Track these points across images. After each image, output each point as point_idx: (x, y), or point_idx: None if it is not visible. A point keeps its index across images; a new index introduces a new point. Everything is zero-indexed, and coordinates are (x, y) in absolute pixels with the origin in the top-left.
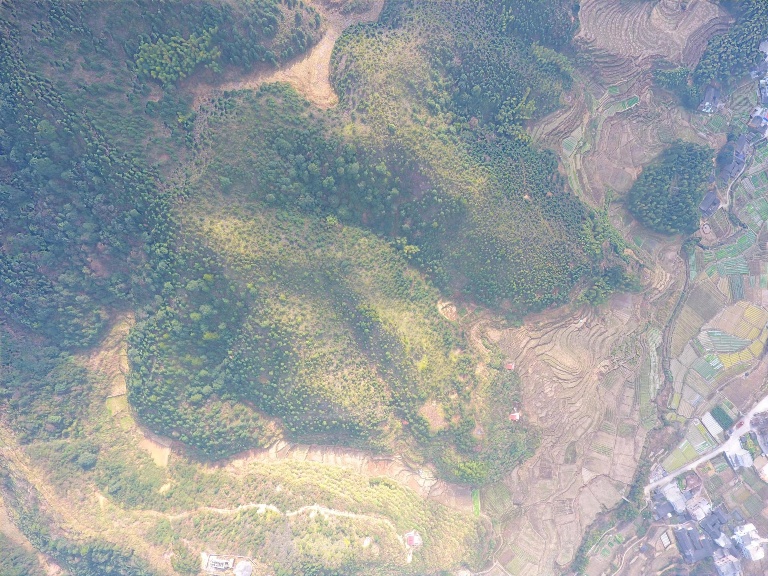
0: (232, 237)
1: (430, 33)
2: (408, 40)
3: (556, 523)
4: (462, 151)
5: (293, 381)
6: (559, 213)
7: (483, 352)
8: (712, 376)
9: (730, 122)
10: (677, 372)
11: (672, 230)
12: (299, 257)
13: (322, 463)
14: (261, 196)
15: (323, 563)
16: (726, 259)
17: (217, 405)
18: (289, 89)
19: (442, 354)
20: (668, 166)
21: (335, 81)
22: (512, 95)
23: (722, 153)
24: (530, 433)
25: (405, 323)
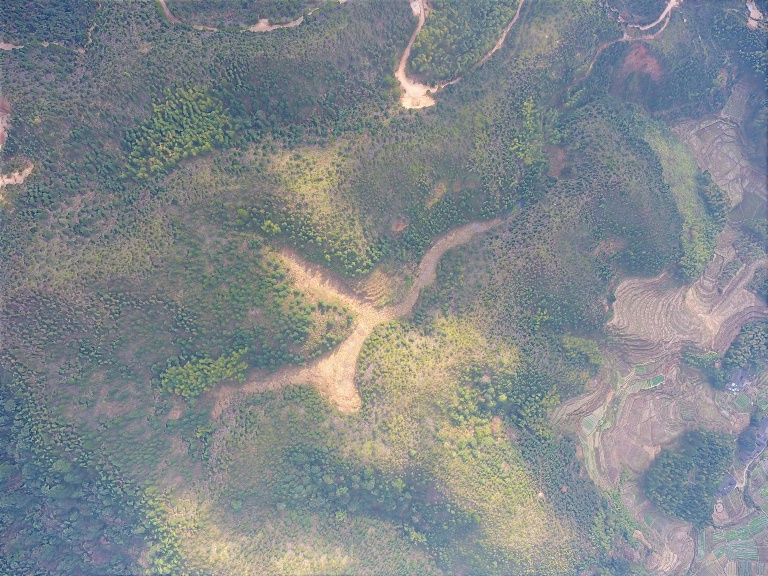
0: (237, 562)
1: (462, 354)
2: (439, 359)
3: None
4: (481, 465)
5: None
6: (572, 510)
7: None
8: None
9: (755, 402)
10: None
11: (685, 522)
12: (303, 569)
13: None
14: (272, 503)
15: None
16: (736, 542)
17: None
18: (313, 396)
19: None
20: (688, 462)
21: (360, 386)
22: (537, 390)
23: (743, 440)
24: None
25: None
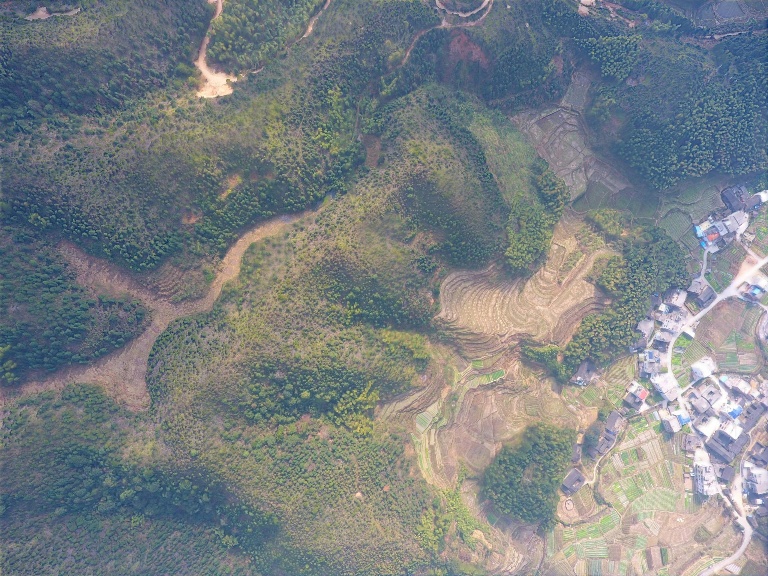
0: (0, 570)
1: (250, 349)
2: (225, 355)
3: None
4: (279, 464)
5: None
6: (394, 510)
7: None
8: None
9: (603, 396)
10: None
11: (522, 521)
12: None
13: None
14: (51, 508)
15: None
16: (586, 540)
17: None
18: (94, 396)
19: None
20: (521, 458)
21: (149, 384)
22: (353, 387)
23: (588, 435)
24: None
25: None
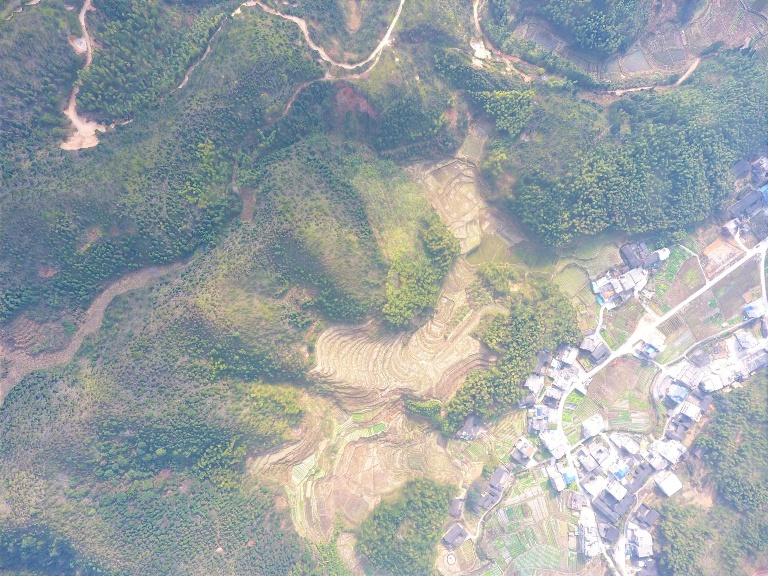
0: None
1: (97, 408)
2: (72, 413)
3: None
4: (129, 522)
5: None
6: (257, 565)
7: None
8: None
9: (489, 451)
10: None
11: None
12: None
13: None
14: None
15: None
16: None
17: None
18: None
19: None
20: (393, 515)
21: None
22: (218, 442)
23: (469, 491)
24: None
25: None
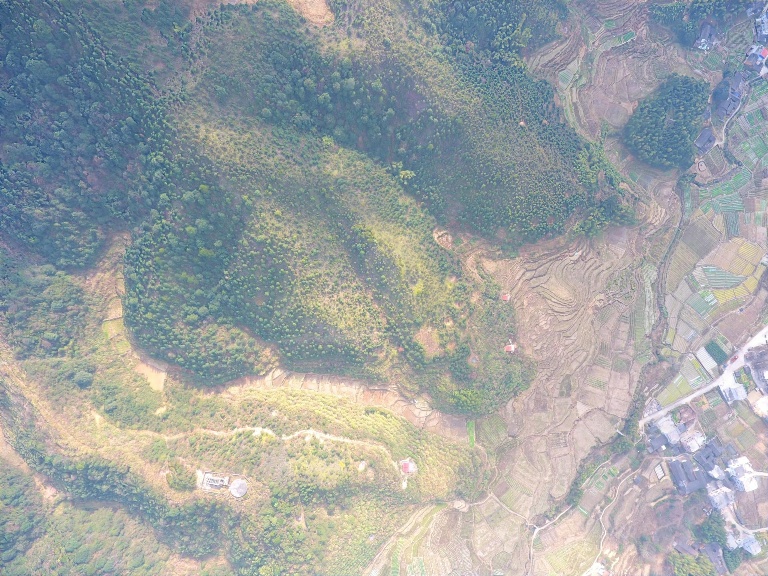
0: (228, 147)
1: None
2: None
3: (551, 456)
4: (458, 71)
5: (289, 302)
6: (555, 141)
7: (478, 281)
8: (707, 312)
9: (726, 60)
10: (672, 308)
11: (667, 163)
12: (295, 172)
13: (318, 391)
14: (257, 111)
15: (318, 483)
16: (721, 196)
17: (213, 327)
18: (285, 5)
19: (437, 280)
20: (664, 98)
21: None
22: (508, 21)
23: (718, 89)
24: (525, 365)
25: (401, 246)
